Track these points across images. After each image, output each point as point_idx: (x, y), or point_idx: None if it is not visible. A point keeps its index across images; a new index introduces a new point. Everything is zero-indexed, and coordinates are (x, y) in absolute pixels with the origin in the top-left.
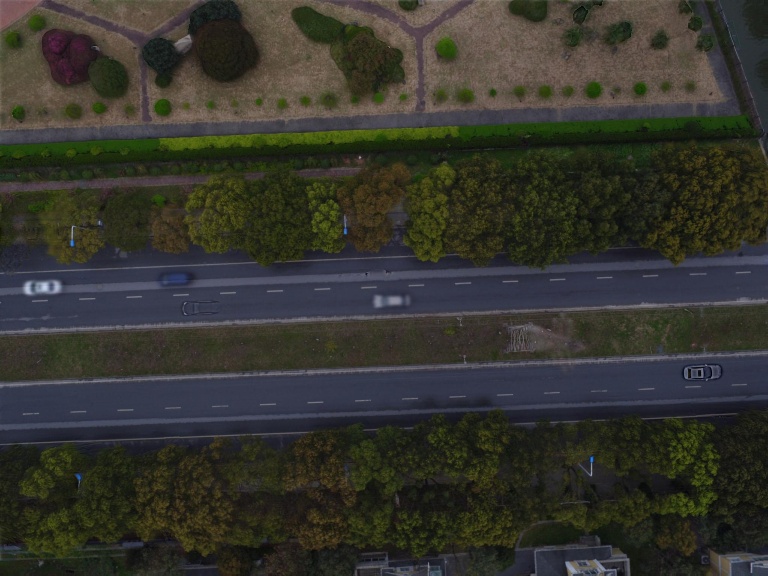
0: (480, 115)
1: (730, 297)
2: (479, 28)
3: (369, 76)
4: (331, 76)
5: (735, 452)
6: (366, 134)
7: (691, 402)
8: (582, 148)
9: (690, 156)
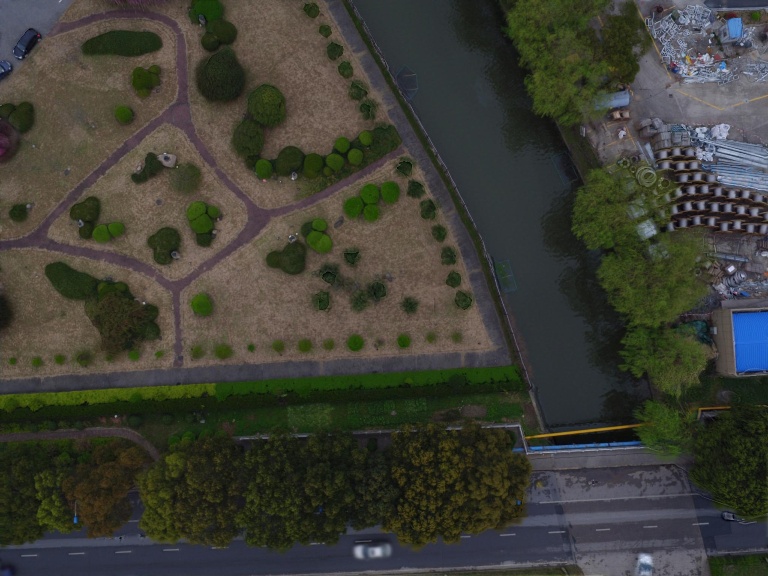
0: (239, 369)
1: (493, 561)
2: (237, 281)
3: (117, 340)
4: (86, 333)
5: None
6: (121, 393)
7: None
8: (342, 405)
9: (417, 450)
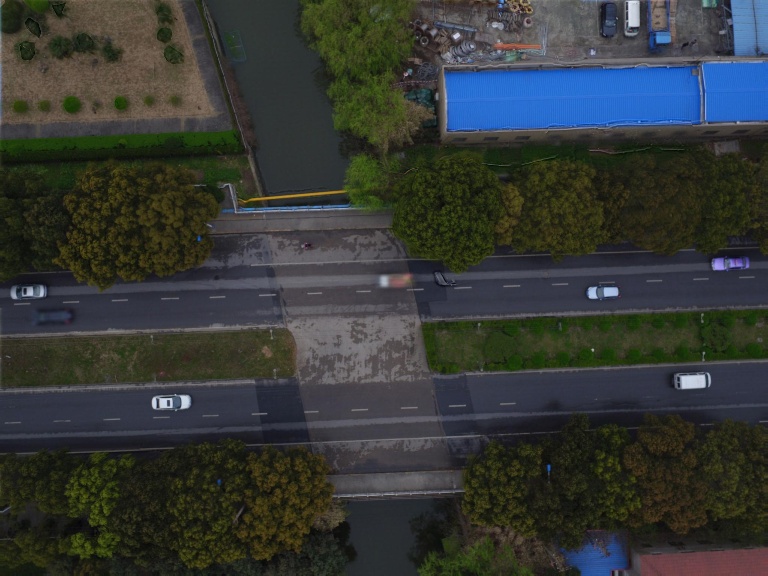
0: None
1: (202, 323)
2: None
3: None
4: None
5: (133, 491)
6: None
7: (157, 433)
8: (55, 166)
9: (89, 177)
